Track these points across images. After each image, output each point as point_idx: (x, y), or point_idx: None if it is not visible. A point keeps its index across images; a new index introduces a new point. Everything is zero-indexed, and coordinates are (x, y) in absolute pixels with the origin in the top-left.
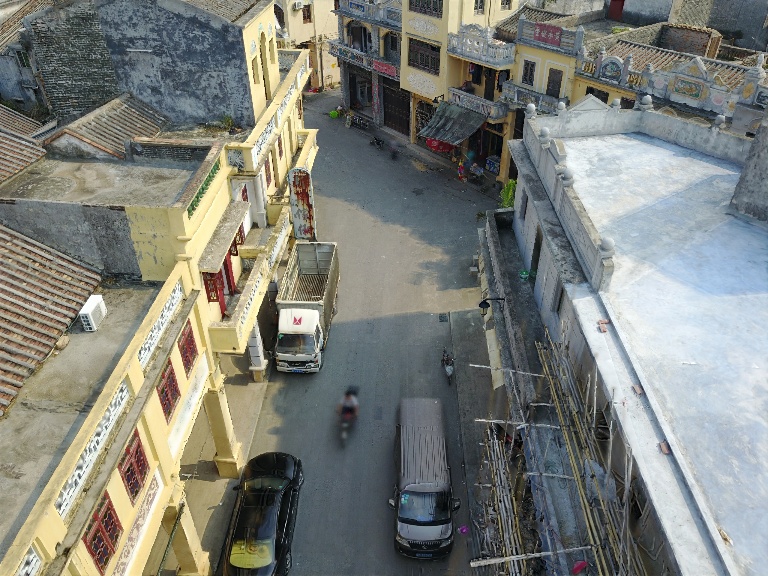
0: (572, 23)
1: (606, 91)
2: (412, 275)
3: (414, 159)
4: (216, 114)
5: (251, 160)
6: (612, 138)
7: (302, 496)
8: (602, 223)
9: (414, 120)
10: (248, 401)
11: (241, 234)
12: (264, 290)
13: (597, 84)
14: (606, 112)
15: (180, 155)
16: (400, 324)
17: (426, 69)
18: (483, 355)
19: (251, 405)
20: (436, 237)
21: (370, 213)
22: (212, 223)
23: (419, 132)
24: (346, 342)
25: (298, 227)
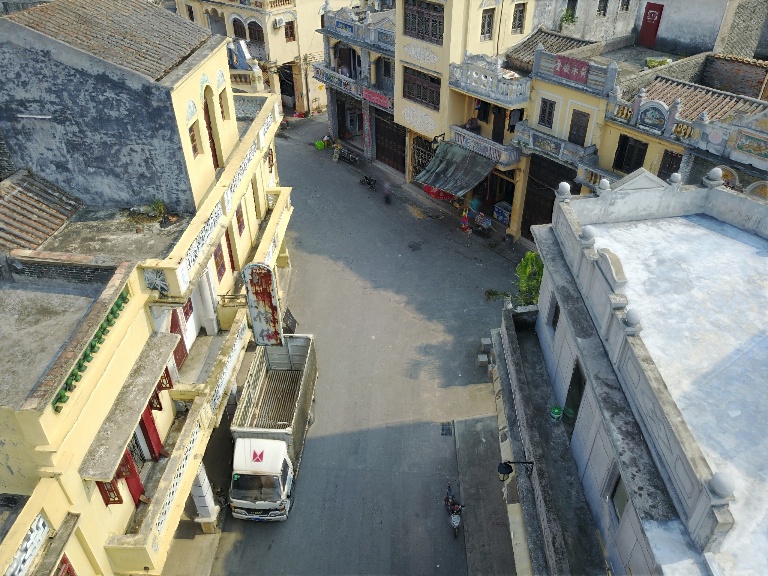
0: (597, 52)
1: (645, 141)
2: (407, 365)
3: (410, 203)
4: (144, 197)
5: (176, 283)
6: (669, 224)
7: None
8: (683, 388)
9: (410, 157)
10: (193, 565)
11: (168, 376)
12: (202, 450)
13: (633, 132)
14: (662, 191)
15: (76, 275)
16: (392, 439)
17: (424, 103)
18: (498, 489)
19: (196, 572)
20: (436, 309)
21: (358, 276)
22: (114, 385)
23: (416, 177)
24: (324, 467)
25: (259, 332)
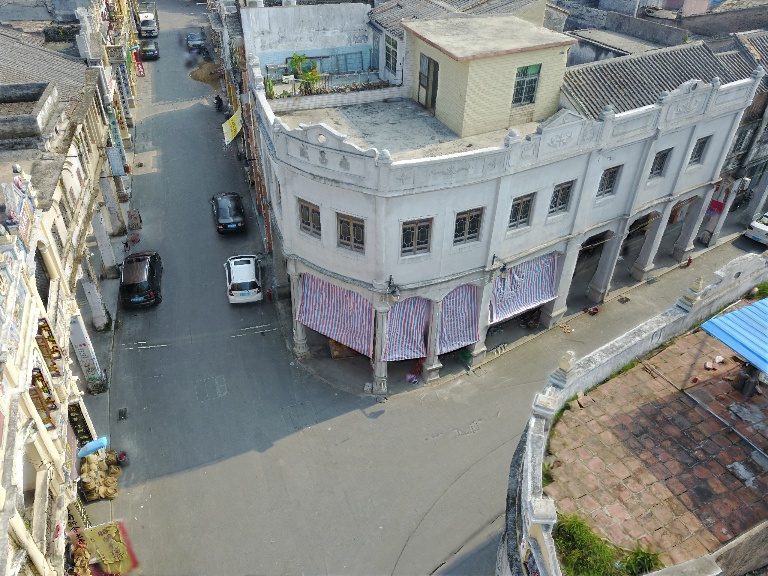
0: None
1: None
2: None
3: None
4: None
5: None
6: None
7: (160, 51)
8: None
9: None
10: None
11: None
12: None
13: None
14: None
15: None
16: (185, 29)
17: None
18: None
19: None
20: None
21: (166, 11)
22: None
23: None
24: (165, 33)
25: None
